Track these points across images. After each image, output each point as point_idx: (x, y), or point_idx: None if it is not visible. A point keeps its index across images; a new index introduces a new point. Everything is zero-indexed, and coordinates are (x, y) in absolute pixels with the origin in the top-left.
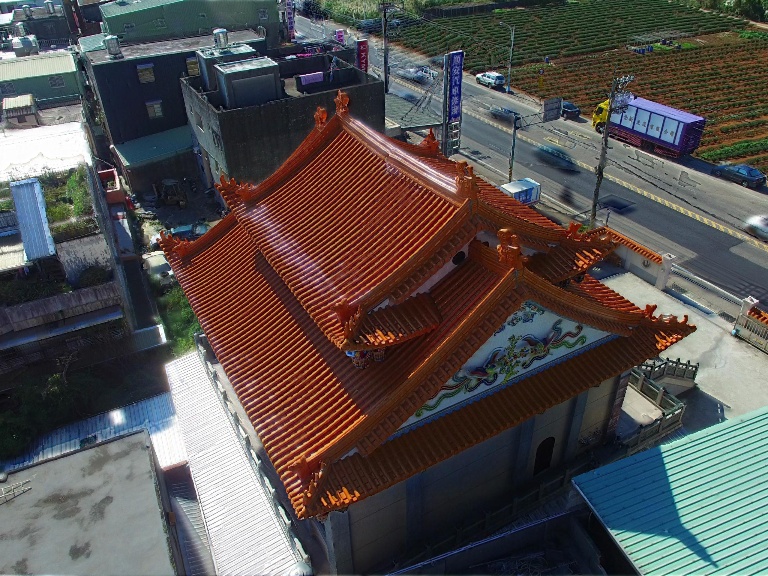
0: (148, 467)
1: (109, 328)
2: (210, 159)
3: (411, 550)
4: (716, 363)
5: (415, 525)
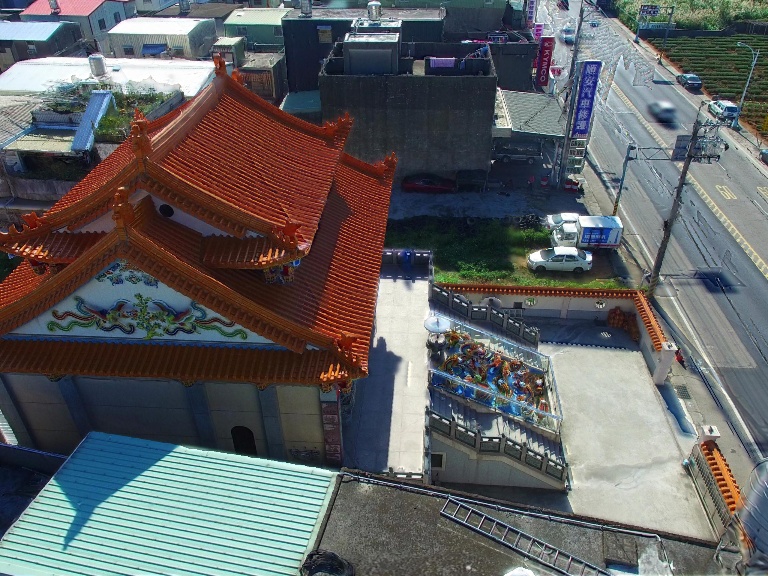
0: None
1: None
2: None
3: None
4: (622, 481)
5: None
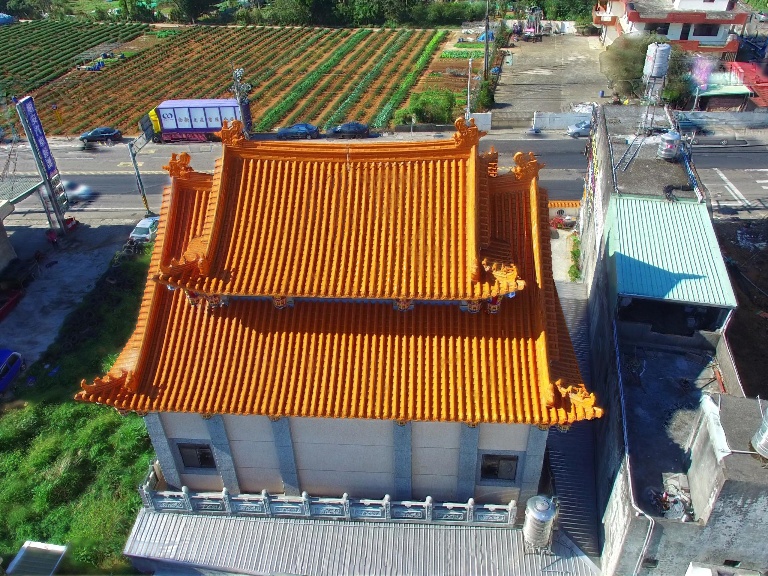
0: None
1: None
2: None
3: None
4: None
5: None
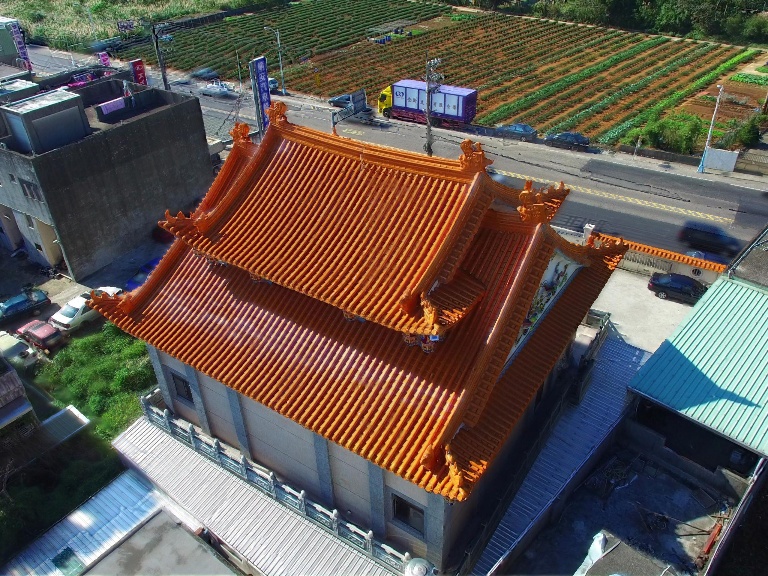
0: (194, 543)
1: (16, 427)
2: (16, 215)
3: (481, 511)
4: None
5: (483, 486)
